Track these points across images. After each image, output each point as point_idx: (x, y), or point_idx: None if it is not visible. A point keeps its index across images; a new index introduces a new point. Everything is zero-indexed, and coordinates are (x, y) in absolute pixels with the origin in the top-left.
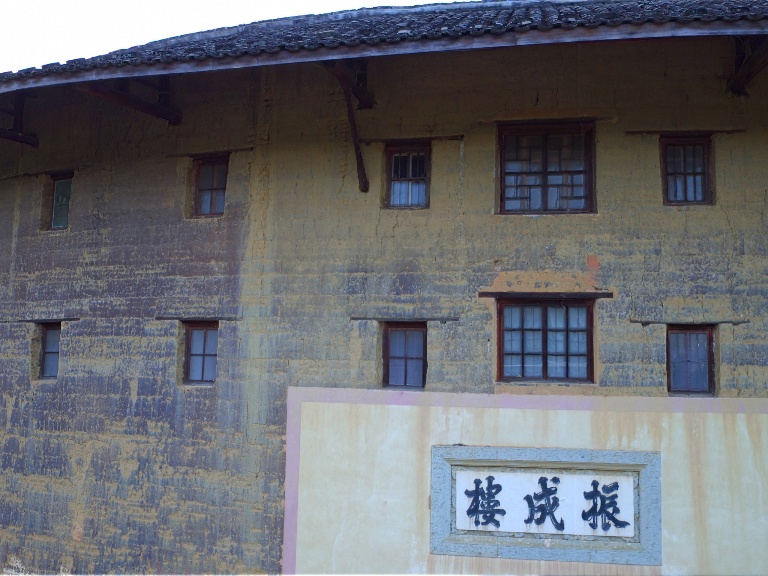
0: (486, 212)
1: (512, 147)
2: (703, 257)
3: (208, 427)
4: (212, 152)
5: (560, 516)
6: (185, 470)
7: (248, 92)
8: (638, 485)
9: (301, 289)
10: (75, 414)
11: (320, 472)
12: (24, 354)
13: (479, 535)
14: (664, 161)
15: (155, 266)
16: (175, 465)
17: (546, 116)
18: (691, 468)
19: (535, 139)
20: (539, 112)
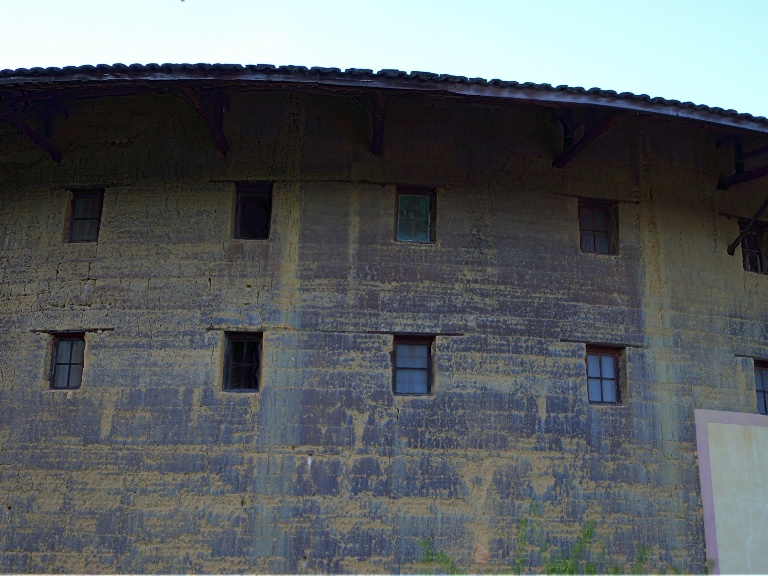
0: None
1: None
2: None
3: (626, 443)
4: (600, 198)
5: None
6: (608, 484)
7: (629, 154)
8: None
9: (695, 326)
10: (466, 431)
11: (729, 483)
12: (381, 367)
13: None
14: None
15: (555, 291)
16: (597, 479)
17: None
18: None
19: None
20: None
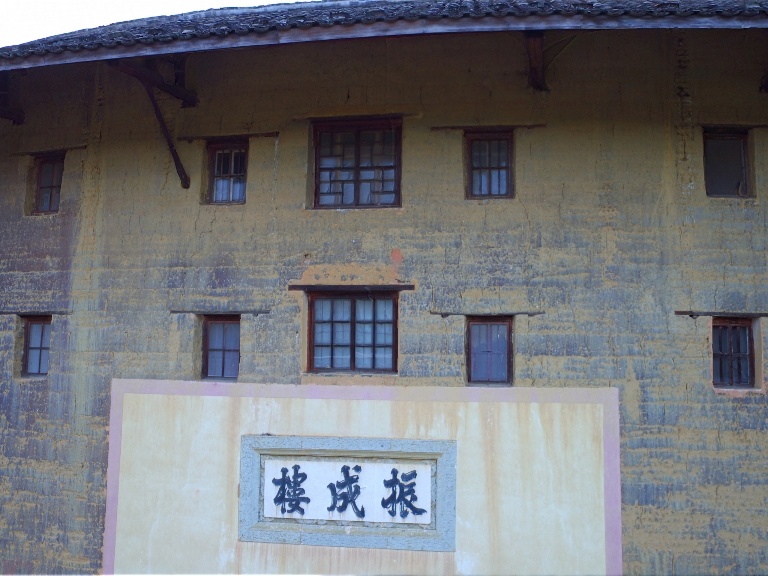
0: (297, 207)
1: (327, 143)
2: (501, 250)
3: (40, 418)
4: (50, 150)
5: (361, 504)
6: (19, 460)
7: (83, 92)
8: (435, 473)
9: (126, 283)
10: None
11: (139, 462)
12: None
13: (285, 522)
14: (470, 156)
15: None
16: (10, 456)
17: (356, 113)
18: (485, 456)
19: (349, 135)
20: (350, 109)
